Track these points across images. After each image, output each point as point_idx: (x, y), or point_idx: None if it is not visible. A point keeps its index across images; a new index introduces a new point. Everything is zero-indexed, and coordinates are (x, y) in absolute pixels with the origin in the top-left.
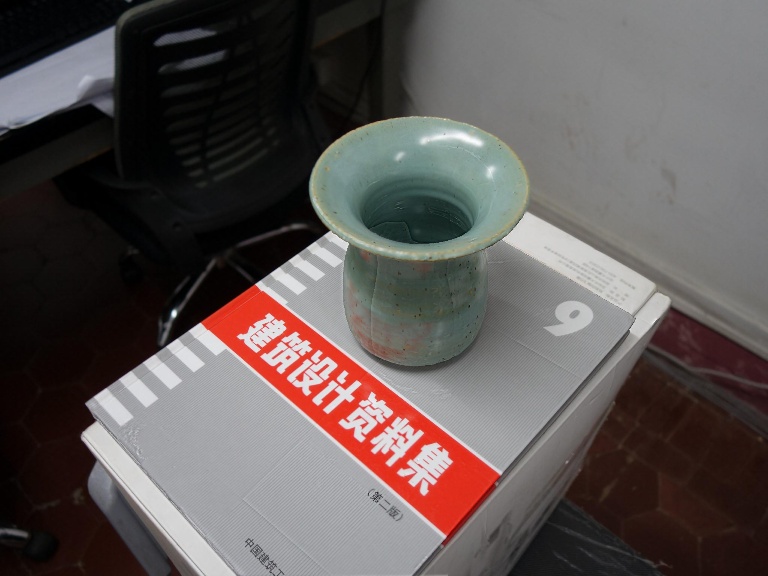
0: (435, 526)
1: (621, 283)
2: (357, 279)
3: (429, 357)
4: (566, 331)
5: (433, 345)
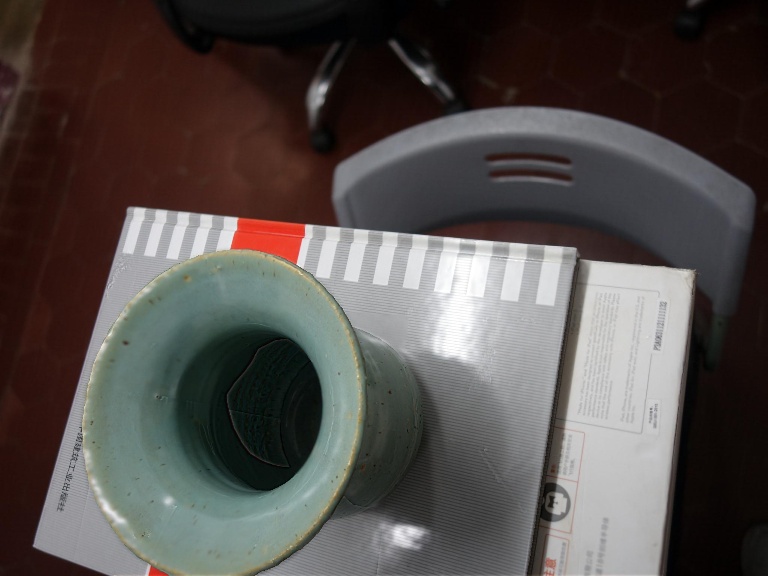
0: (149, 573)
1: None
2: None
3: None
4: None
5: None
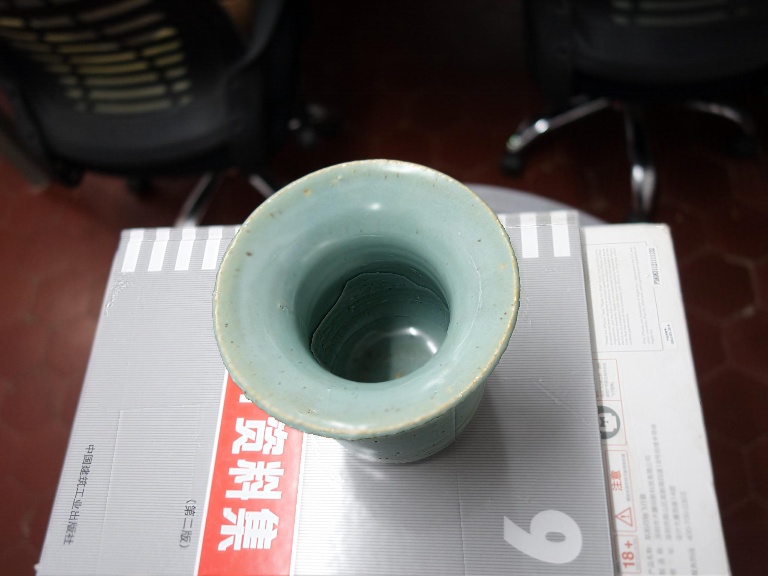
0: None
1: (686, 552)
2: None
3: None
4: (521, 545)
5: None
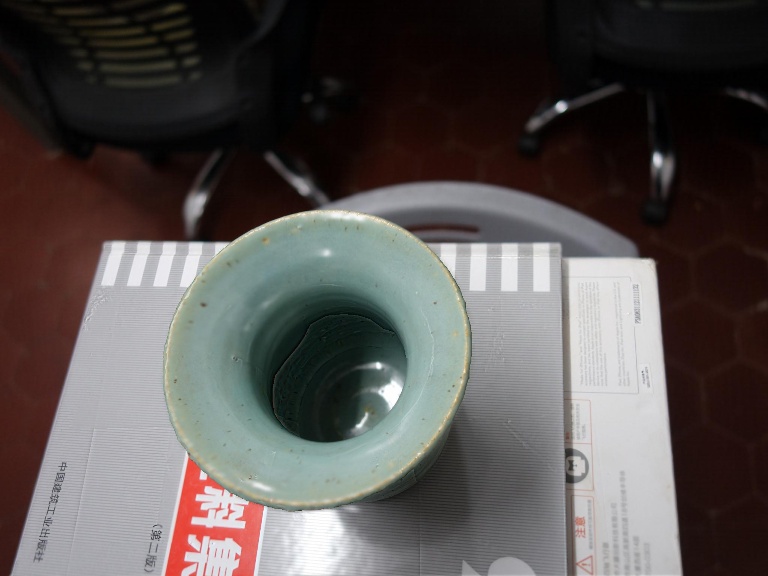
0: None
1: None
2: None
3: None
4: None
5: None
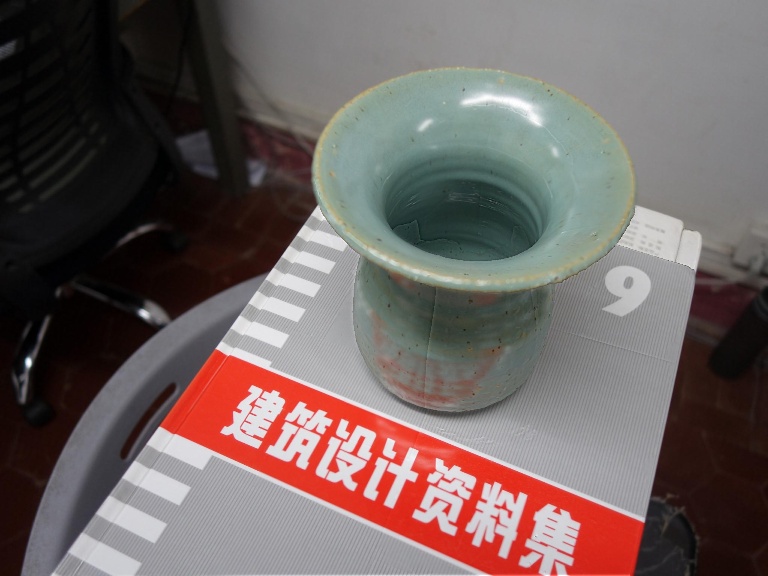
0: None
1: (648, 229)
2: (398, 320)
3: (503, 393)
4: (629, 307)
5: (510, 378)
